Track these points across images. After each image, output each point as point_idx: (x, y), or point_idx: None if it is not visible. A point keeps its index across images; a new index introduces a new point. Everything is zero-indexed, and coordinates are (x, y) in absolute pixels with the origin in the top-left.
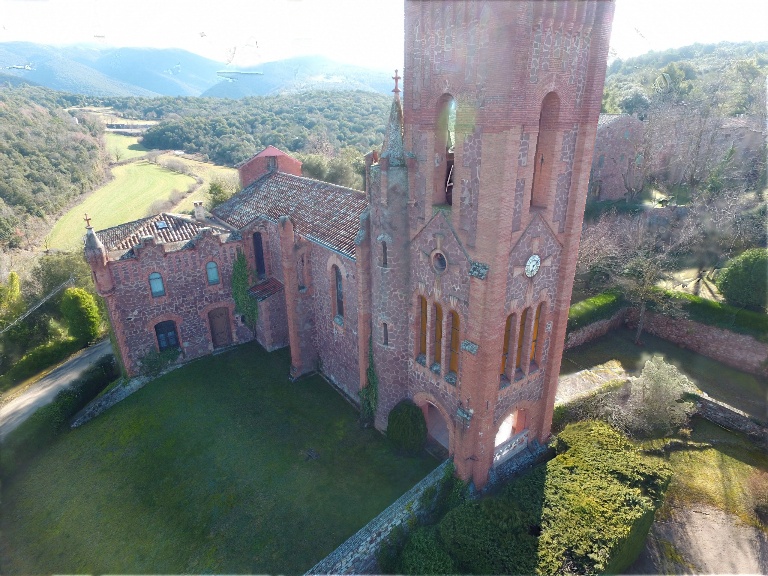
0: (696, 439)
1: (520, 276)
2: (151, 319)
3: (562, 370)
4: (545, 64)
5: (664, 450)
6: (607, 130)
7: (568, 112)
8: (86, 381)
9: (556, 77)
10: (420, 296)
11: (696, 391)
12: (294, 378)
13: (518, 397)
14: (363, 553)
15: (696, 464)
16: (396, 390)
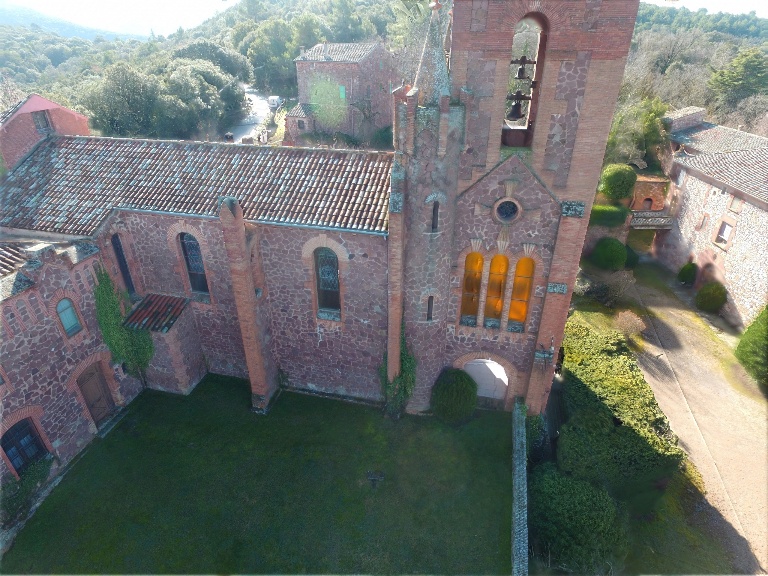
0: None
1: None
2: None
3: None
4: None
5: None
6: (368, 60)
7: None
8: None
9: None
10: (467, 254)
11: None
12: (264, 409)
13: None
14: None
15: None
16: (437, 364)
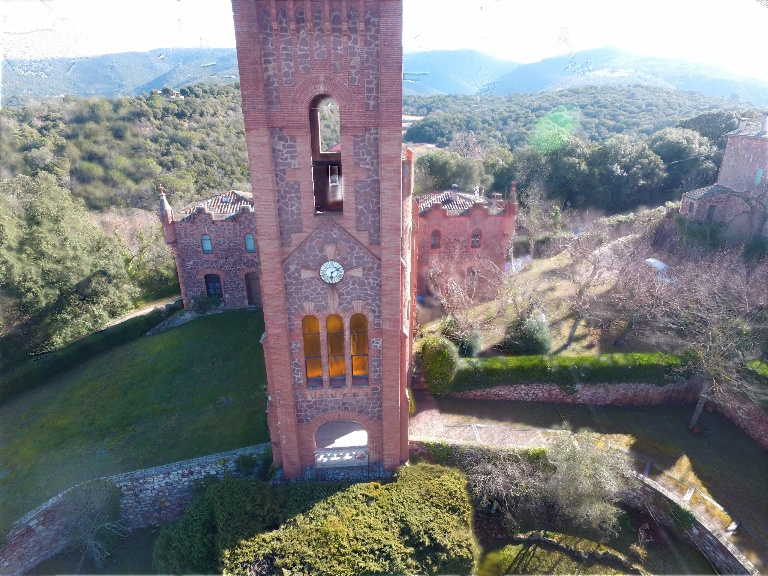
0: (652, 567)
1: (315, 279)
2: (202, 270)
3: (534, 420)
4: (305, 66)
5: (588, 556)
6: None
7: (356, 115)
8: (173, 307)
9: (325, 79)
10: None
11: (721, 516)
12: None
13: (341, 406)
14: (176, 481)
15: None
16: None
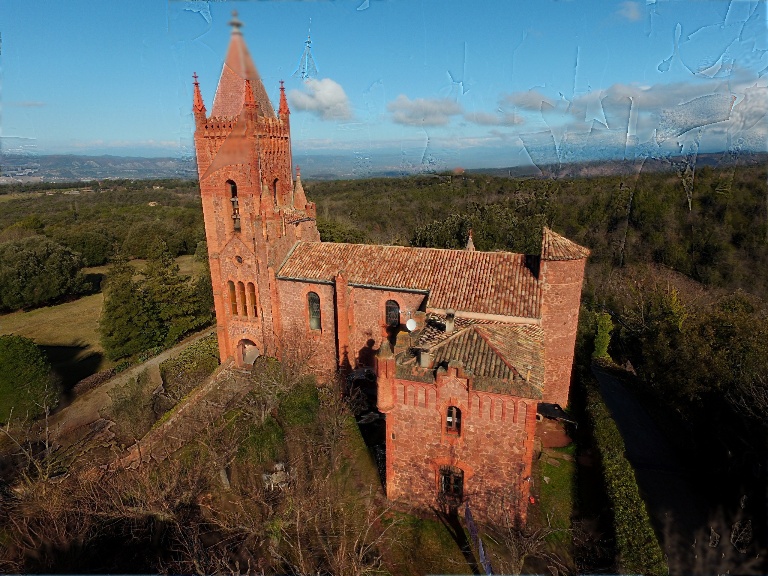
0: None
1: None
2: None
3: None
4: None
5: None
6: None
7: None
8: None
9: None
10: None
11: None
12: None
13: None
14: None
15: None
16: None
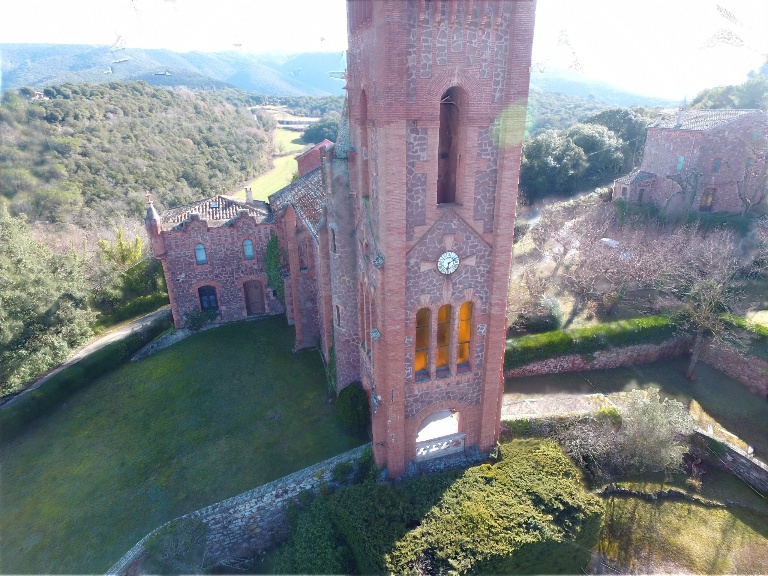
0: (708, 495)
1: (432, 272)
2: (195, 282)
3: (570, 389)
4: (441, 59)
5: (657, 497)
6: (726, 129)
7: (482, 107)
8: (152, 327)
9: (459, 71)
10: None
11: (739, 443)
12: (295, 350)
13: (445, 396)
14: (269, 504)
15: (693, 522)
16: (349, 371)
